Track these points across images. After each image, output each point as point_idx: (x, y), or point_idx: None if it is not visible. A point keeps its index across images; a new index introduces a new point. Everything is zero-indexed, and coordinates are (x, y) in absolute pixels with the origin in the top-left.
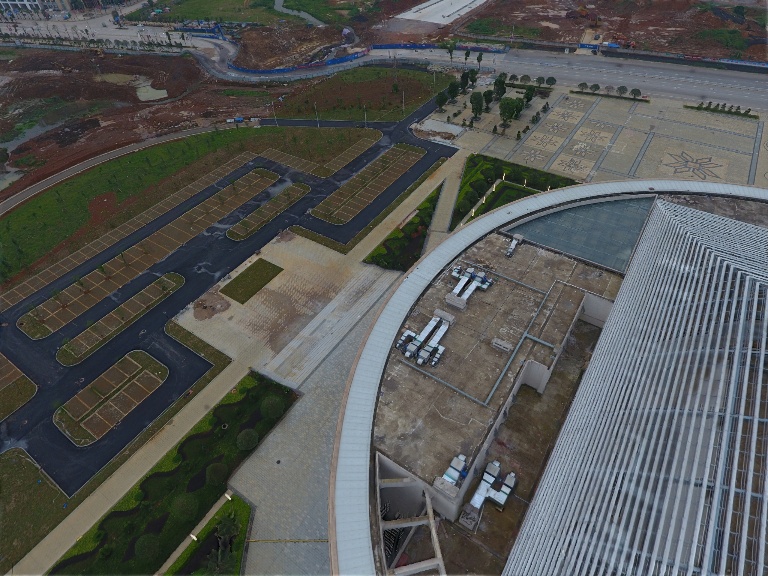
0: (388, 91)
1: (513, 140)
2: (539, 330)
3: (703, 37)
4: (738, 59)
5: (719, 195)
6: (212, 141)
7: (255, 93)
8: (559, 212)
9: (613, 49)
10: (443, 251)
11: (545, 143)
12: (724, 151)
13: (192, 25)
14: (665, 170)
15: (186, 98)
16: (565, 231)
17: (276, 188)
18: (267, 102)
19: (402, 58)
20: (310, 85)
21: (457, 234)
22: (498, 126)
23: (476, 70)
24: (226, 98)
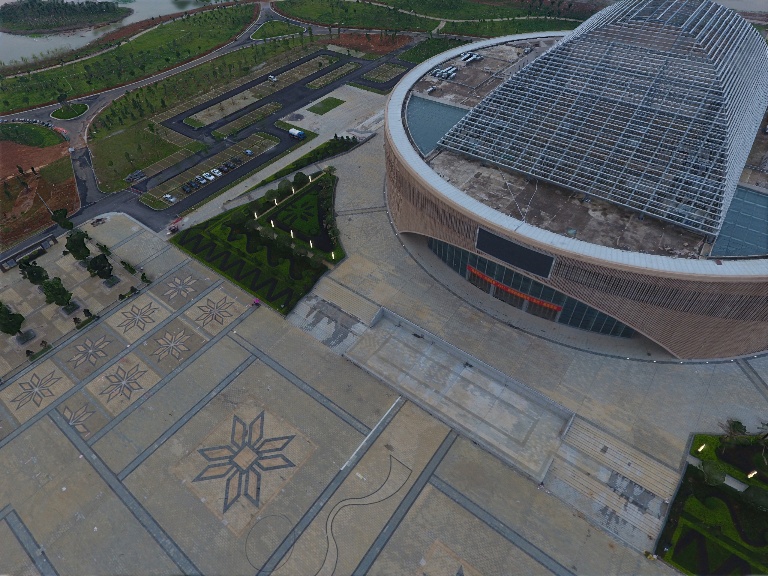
0: None
1: None
2: None
3: None
4: None
5: None
6: None
7: None
8: None
9: None
10: None
11: None
12: None
13: None
14: None
15: None
16: None
17: None
18: None
19: None
20: None
21: None
22: None
23: None
24: None
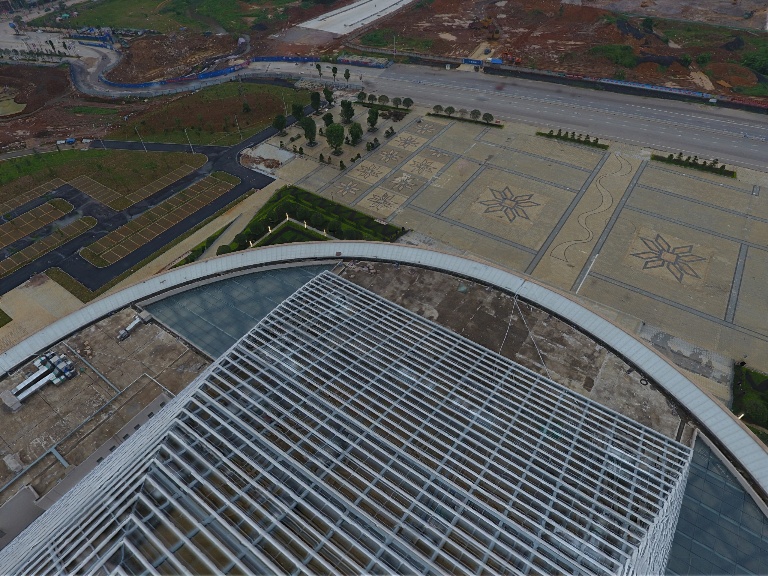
0: (240, 110)
1: (337, 170)
2: (75, 442)
3: (595, 53)
4: (618, 79)
5: (408, 263)
6: (27, 166)
7: (103, 111)
8: (225, 280)
9: (496, 65)
10: (52, 331)
11: (368, 174)
12: (550, 187)
13: (90, 32)
14: (476, 209)
15: (33, 115)
16: (212, 306)
17: (62, 222)
18: (110, 121)
19: (276, 72)
20: (165, 102)
21: (84, 309)
22: (330, 153)
23: (344, 87)
24: (71, 116)
